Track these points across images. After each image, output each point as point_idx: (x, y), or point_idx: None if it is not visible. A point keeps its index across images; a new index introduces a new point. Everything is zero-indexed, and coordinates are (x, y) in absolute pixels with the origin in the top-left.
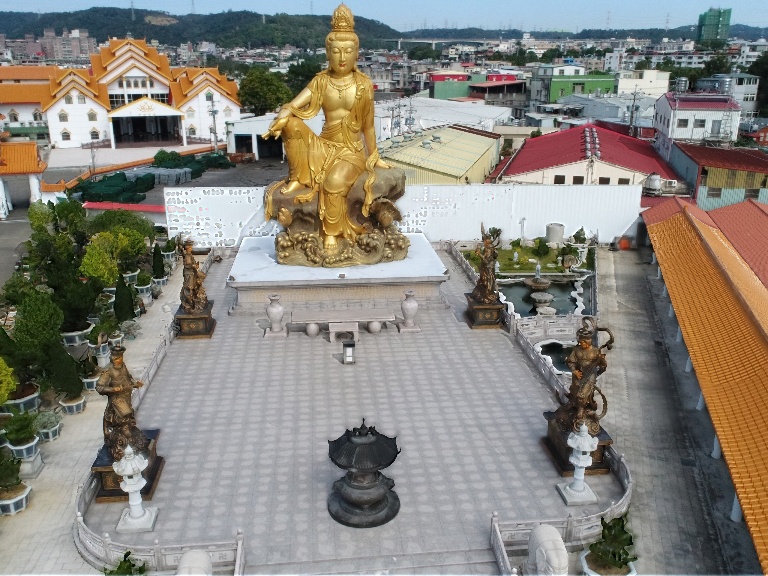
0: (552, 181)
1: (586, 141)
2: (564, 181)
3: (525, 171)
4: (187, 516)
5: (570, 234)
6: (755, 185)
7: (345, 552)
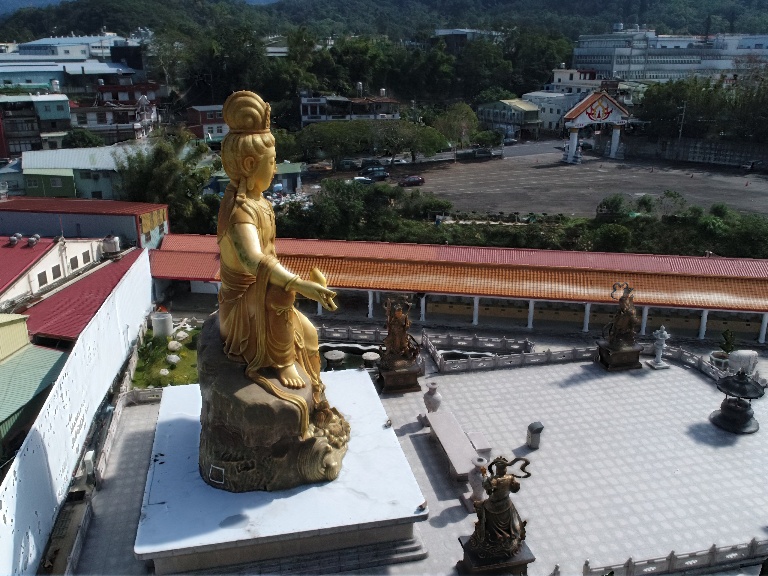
0: (37, 283)
1: None
2: (46, 278)
3: (7, 284)
4: None
5: (139, 323)
6: (161, 220)
7: None
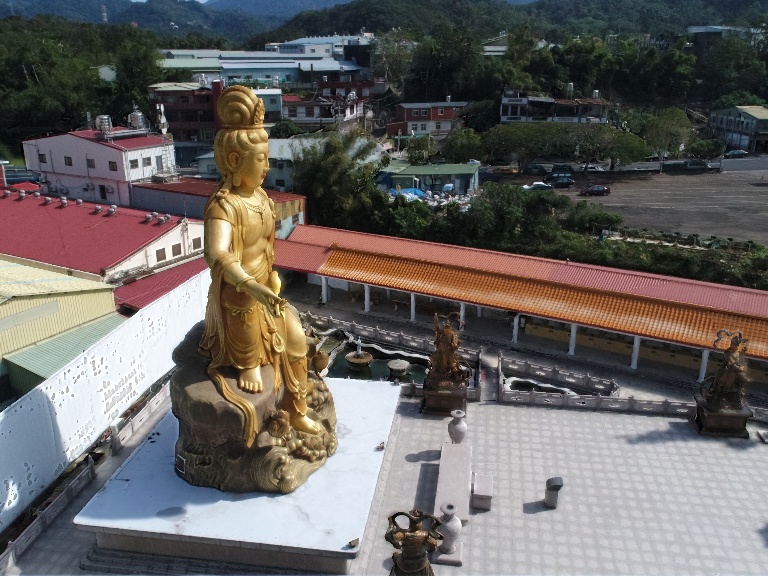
0: (155, 258)
1: (64, 203)
2: (165, 254)
3: (125, 256)
4: None
5: None
6: (296, 211)
7: None
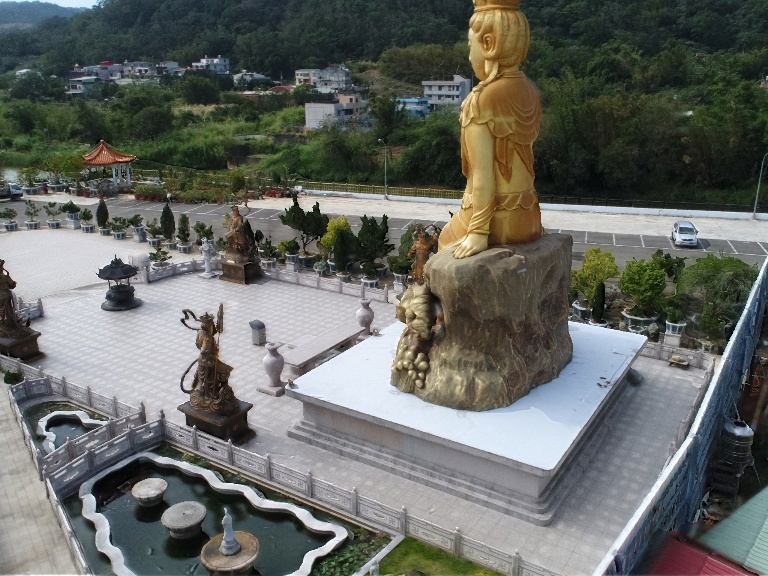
0: None
1: None
2: None
3: None
4: None
5: None
6: None
7: None
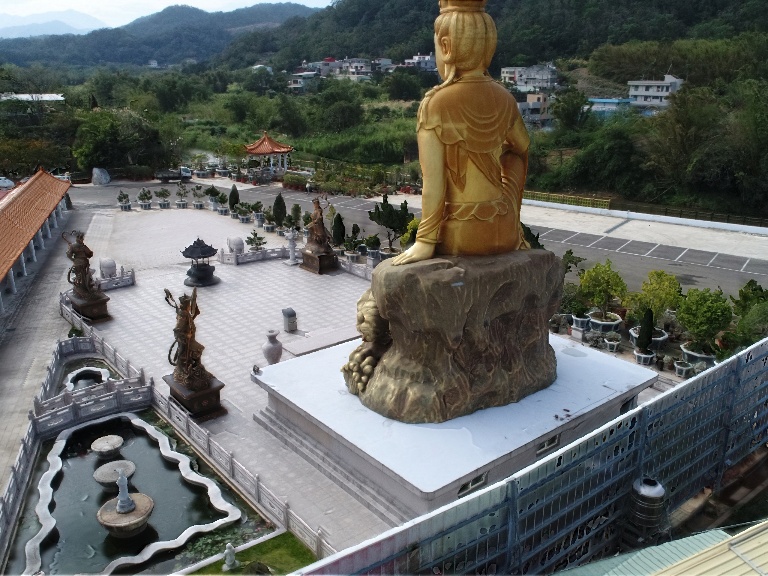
0: None
1: None
2: None
3: None
4: (276, 267)
5: None
6: None
7: None
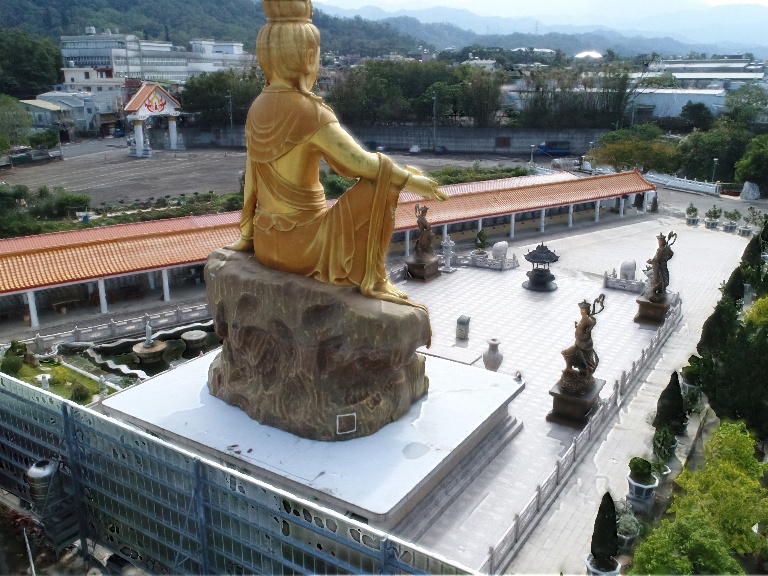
0: None
1: None
2: None
3: None
4: None
5: None
6: None
7: (562, 280)
